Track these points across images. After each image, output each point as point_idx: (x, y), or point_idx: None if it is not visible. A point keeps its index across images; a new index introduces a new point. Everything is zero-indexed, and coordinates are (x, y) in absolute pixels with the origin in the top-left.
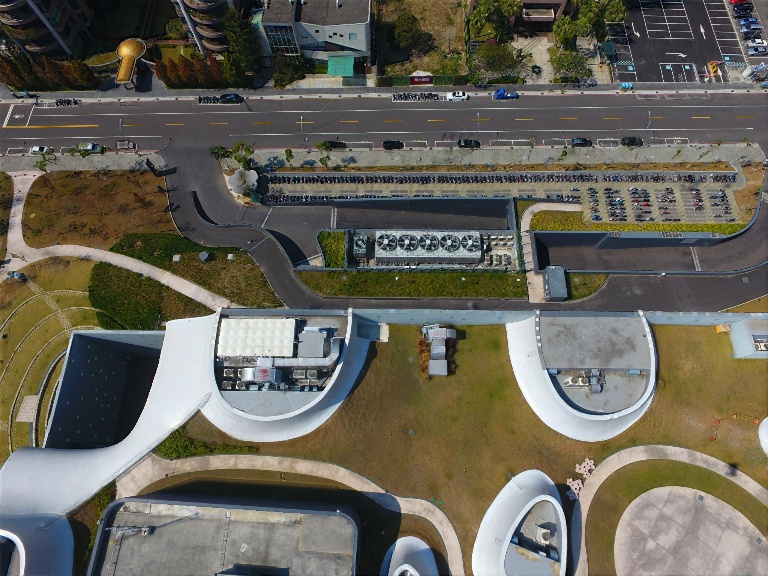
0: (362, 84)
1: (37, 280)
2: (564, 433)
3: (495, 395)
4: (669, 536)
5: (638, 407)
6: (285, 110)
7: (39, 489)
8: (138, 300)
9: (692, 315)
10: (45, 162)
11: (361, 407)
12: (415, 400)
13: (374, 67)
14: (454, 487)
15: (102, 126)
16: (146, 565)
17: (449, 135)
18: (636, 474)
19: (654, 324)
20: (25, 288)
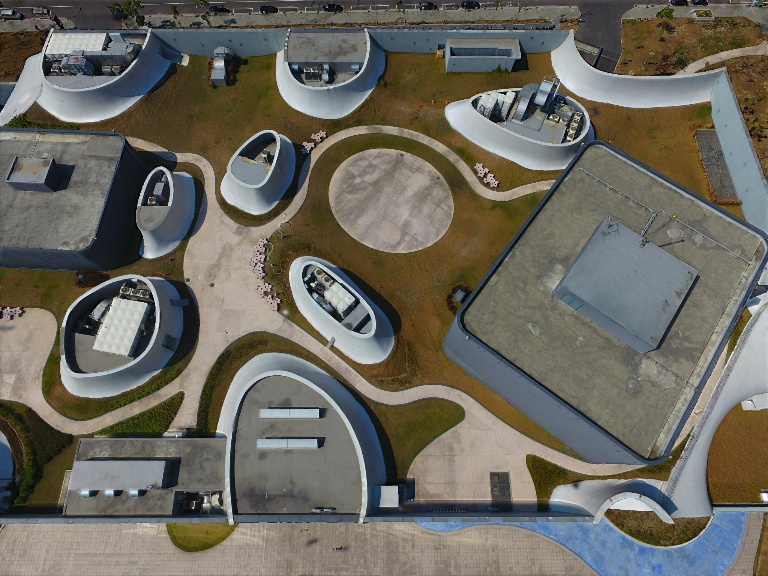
0: None
1: None
2: (303, 111)
3: (262, 96)
4: (373, 176)
5: (349, 82)
6: None
7: None
8: None
9: (404, 31)
10: None
11: (159, 103)
12: (202, 100)
13: None
14: (219, 148)
15: None
16: None
17: (317, 2)
18: (357, 142)
19: (388, 51)
20: None
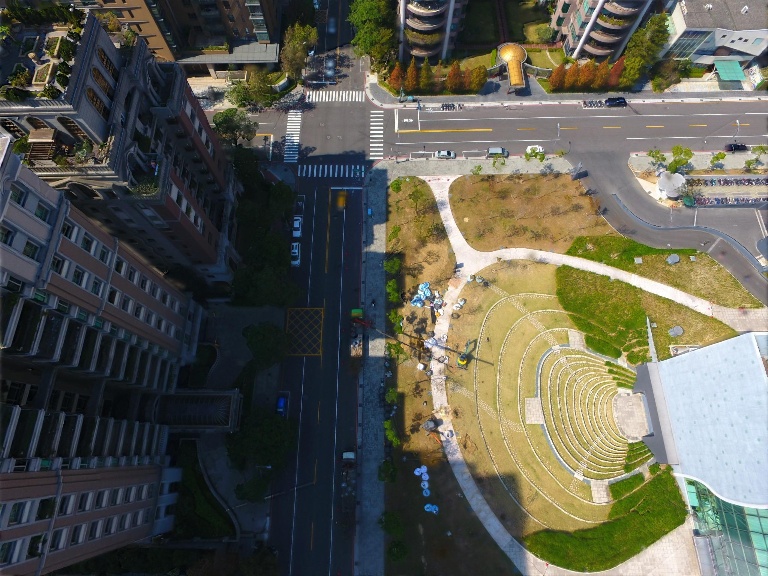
0: (739, 88)
1: (498, 283)
2: None
3: None
4: None
5: None
6: (673, 114)
7: None
8: (616, 302)
9: None
10: None
11: None
12: None
13: (745, 71)
14: None
15: (496, 130)
16: None
17: None
18: None
19: None
20: (489, 292)
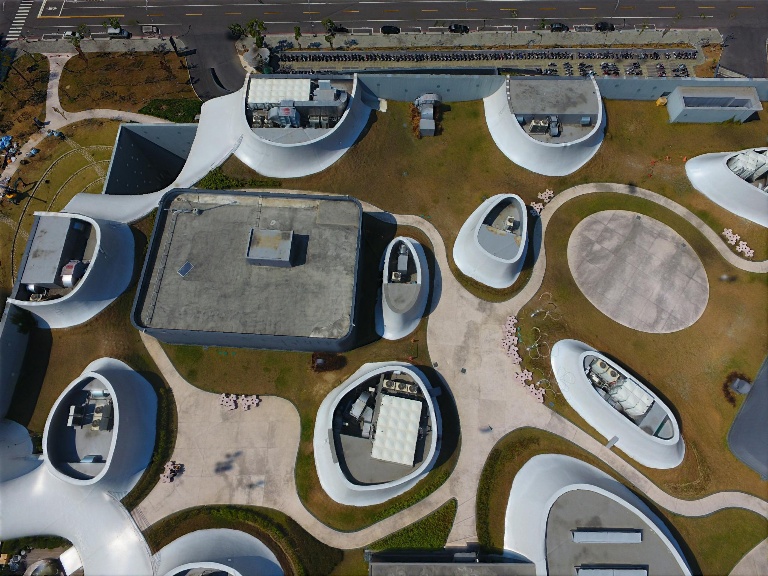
0: None
1: (74, 137)
2: (529, 168)
3: (474, 148)
4: (612, 242)
5: (587, 138)
6: (293, 2)
7: (104, 209)
8: None
9: (634, 79)
10: (79, 38)
11: (364, 155)
12: (408, 152)
13: None
14: (440, 208)
15: (128, 16)
16: (197, 233)
17: (441, 22)
18: (587, 202)
19: (605, 98)
20: (64, 144)
